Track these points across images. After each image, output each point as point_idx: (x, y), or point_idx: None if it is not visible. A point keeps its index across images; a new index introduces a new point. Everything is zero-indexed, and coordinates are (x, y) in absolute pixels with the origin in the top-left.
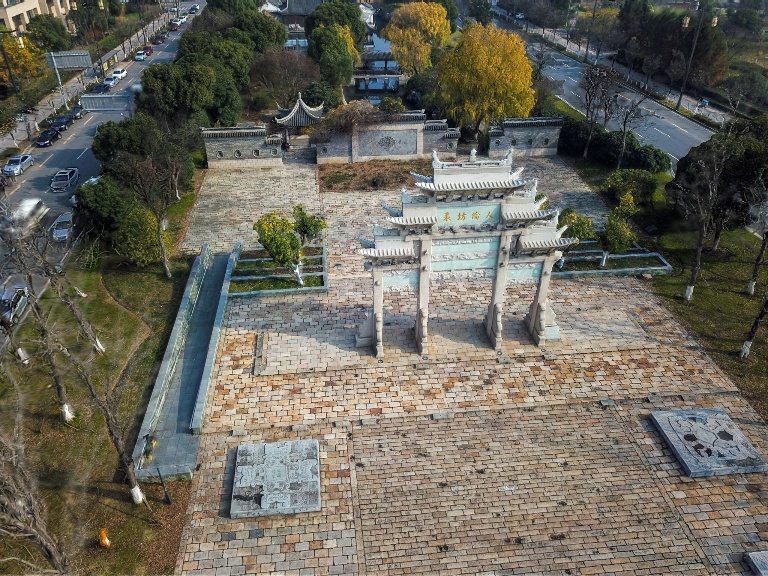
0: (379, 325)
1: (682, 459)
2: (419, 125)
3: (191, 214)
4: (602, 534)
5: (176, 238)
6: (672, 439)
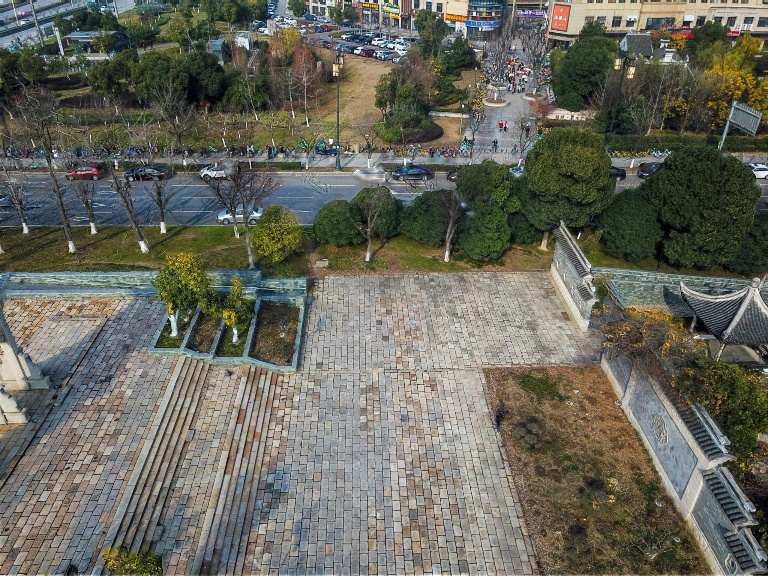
0: (3, 362)
1: None
2: (704, 456)
3: (411, 273)
4: None
5: (351, 270)
6: None
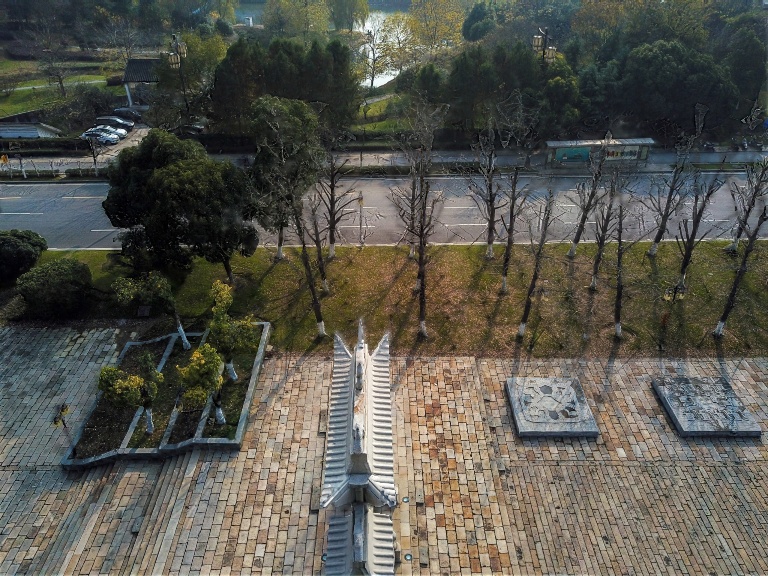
0: None
1: (583, 432)
2: None
3: None
4: (696, 535)
5: None
6: (558, 429)
